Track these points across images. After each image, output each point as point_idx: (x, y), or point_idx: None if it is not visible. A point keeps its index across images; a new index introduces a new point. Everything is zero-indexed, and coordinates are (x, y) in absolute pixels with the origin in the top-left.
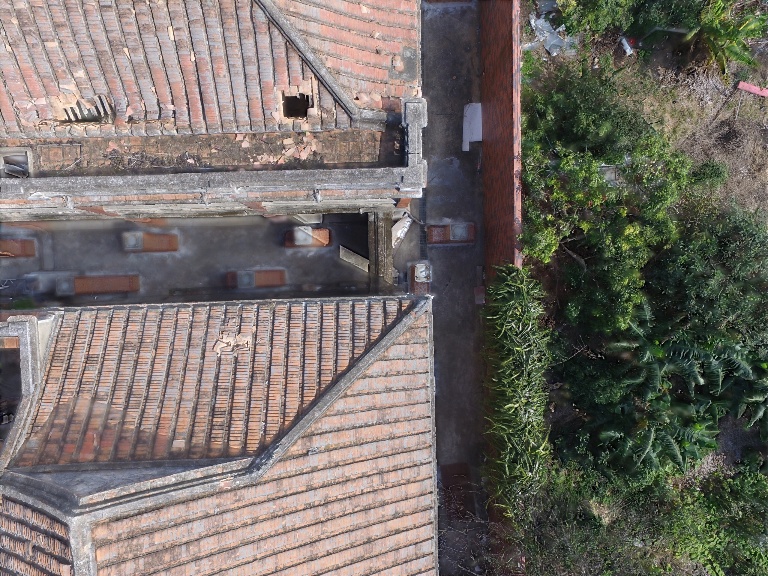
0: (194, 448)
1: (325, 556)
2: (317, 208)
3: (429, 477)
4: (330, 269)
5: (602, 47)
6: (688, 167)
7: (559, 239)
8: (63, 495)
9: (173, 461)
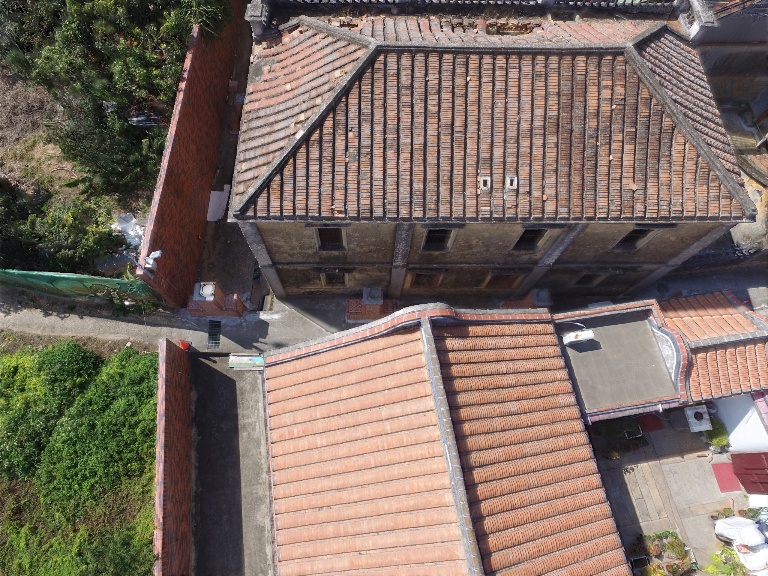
0: None
1: None
2: None
3: None
4: None
5: None
6: (37, 70)
7: None
8: None
9: None
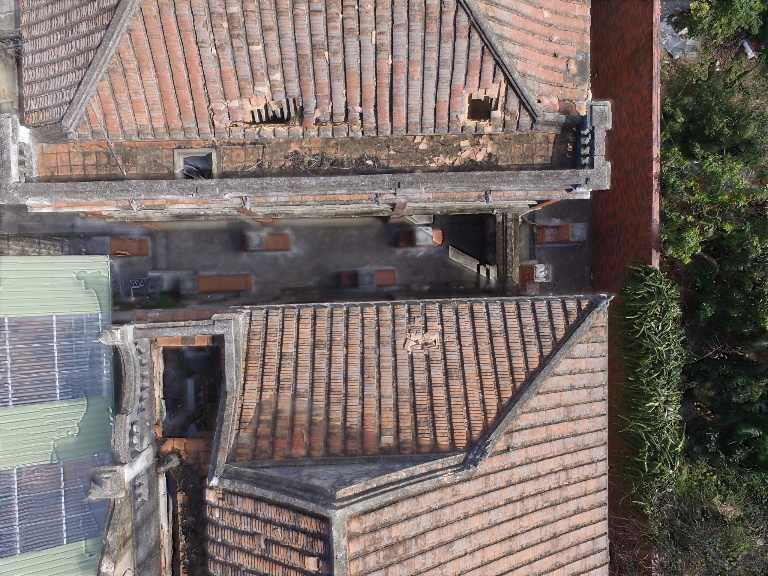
0: (404, 444)
1: (520, 551)
2: (453, 209)
3: (604, 474)
4: (439, 269)
5: (723, 50)
6: None
7: (699, 240)
8: (309, 489)
9: (387, 457)
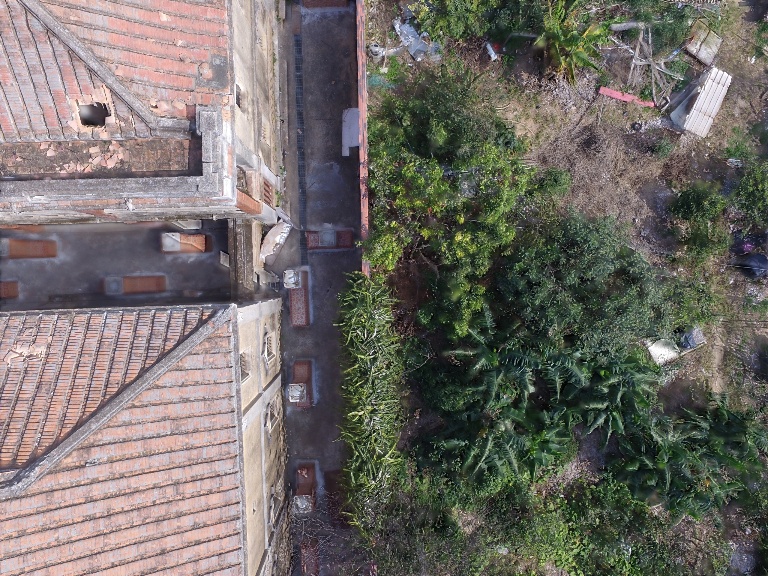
0: None
1: (109, 568)
2: (169, 215)
3: (235, 487)
4: (211, 275)
5: (467, 52)
6: (532, 173)
7: (403, 246)
8: None
9: None
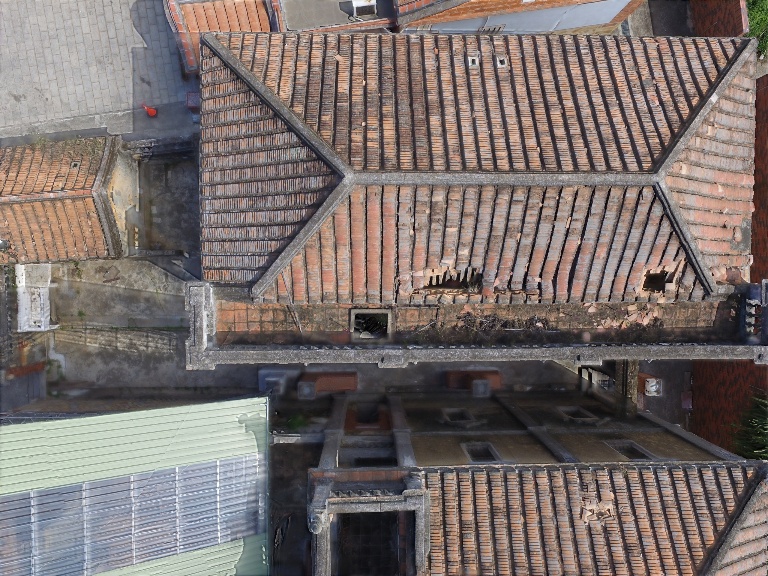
0: None
1: None
2: None
3: None
4: (541, 370)
5: None
6: None
7: None
8: None
9: None
